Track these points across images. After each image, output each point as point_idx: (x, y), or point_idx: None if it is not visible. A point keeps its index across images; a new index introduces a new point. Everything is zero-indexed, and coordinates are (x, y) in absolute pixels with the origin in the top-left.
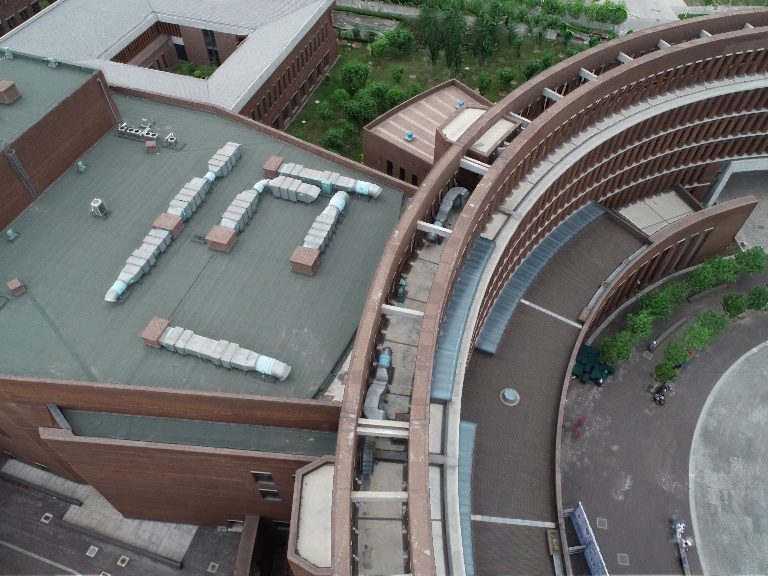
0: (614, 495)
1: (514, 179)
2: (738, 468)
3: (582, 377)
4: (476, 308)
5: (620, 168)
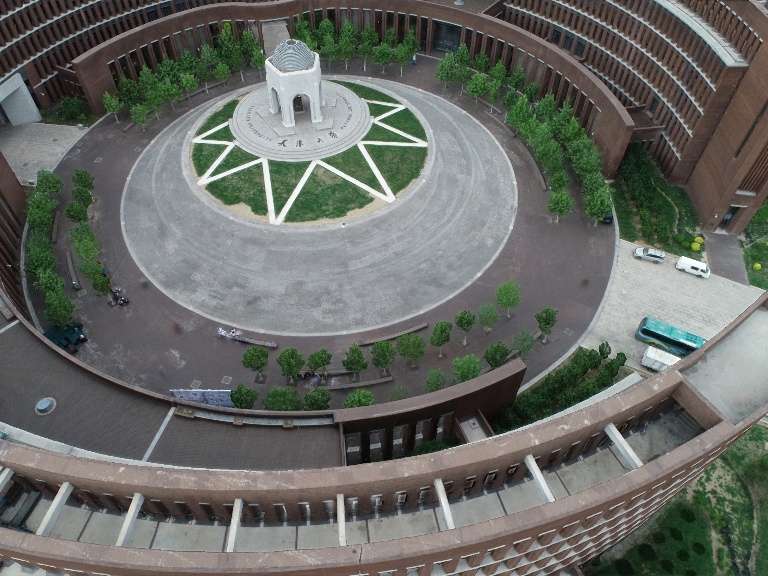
0: (179, 367)
1: None
2: (200, 277)
3: (70, 350)
4: None
5: None
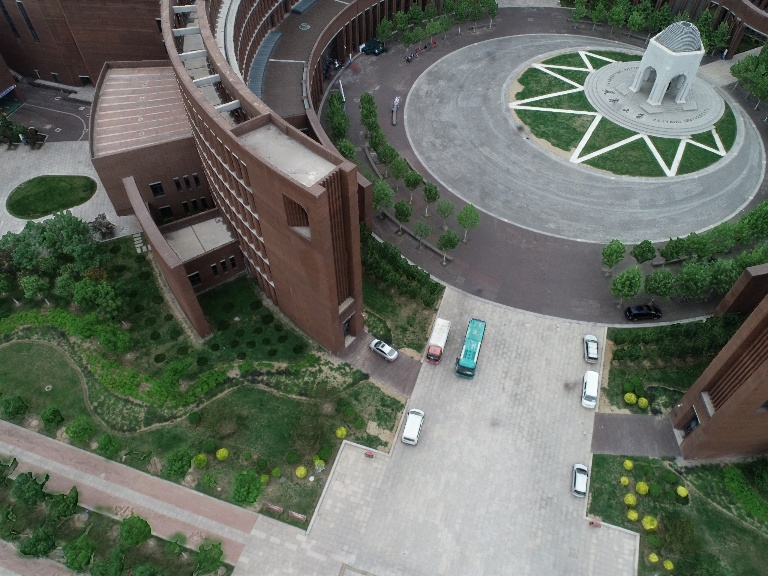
0: (368, 91)
1: None
2: (441, 84)
3: (367, 51)
4: None
5: None
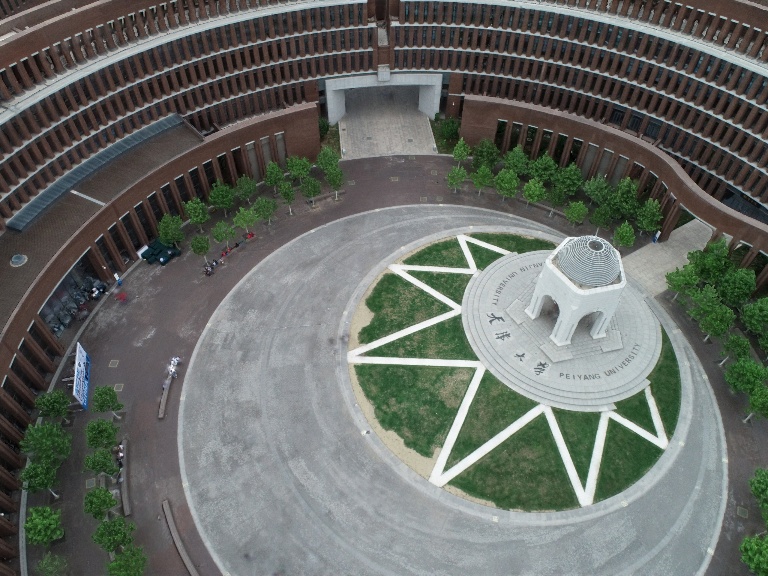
0: (135, 343)
1: None
2: (251, 317)
3: (148, 258)
4: None
5: (193, 83)
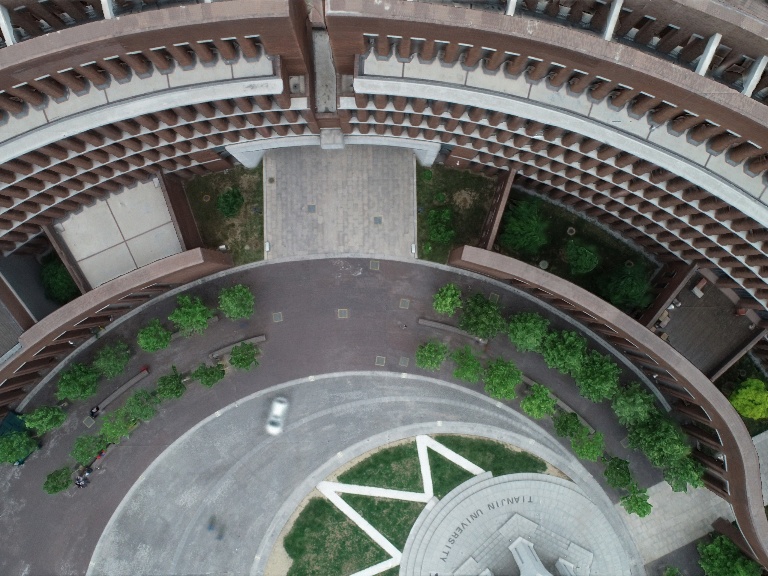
0: None
1: None
2: (142, 556)
3: None
4: None
5: None
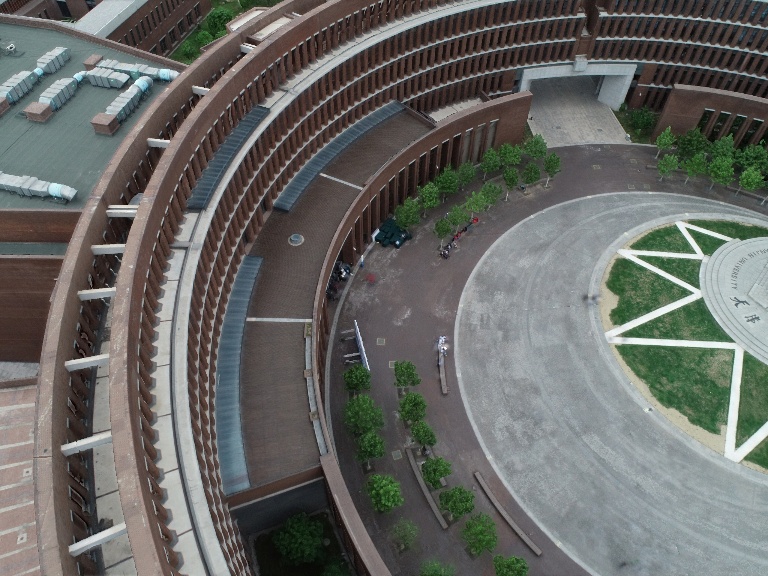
0: (395, 322)
1: (293, 64)
2: (499, 299)
3: (383, 241)
4: (242, 153)
5: (415, 71)
